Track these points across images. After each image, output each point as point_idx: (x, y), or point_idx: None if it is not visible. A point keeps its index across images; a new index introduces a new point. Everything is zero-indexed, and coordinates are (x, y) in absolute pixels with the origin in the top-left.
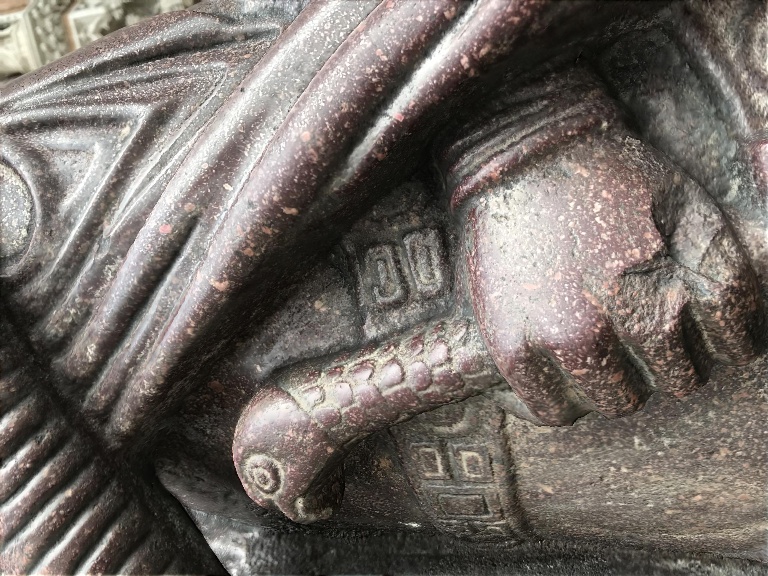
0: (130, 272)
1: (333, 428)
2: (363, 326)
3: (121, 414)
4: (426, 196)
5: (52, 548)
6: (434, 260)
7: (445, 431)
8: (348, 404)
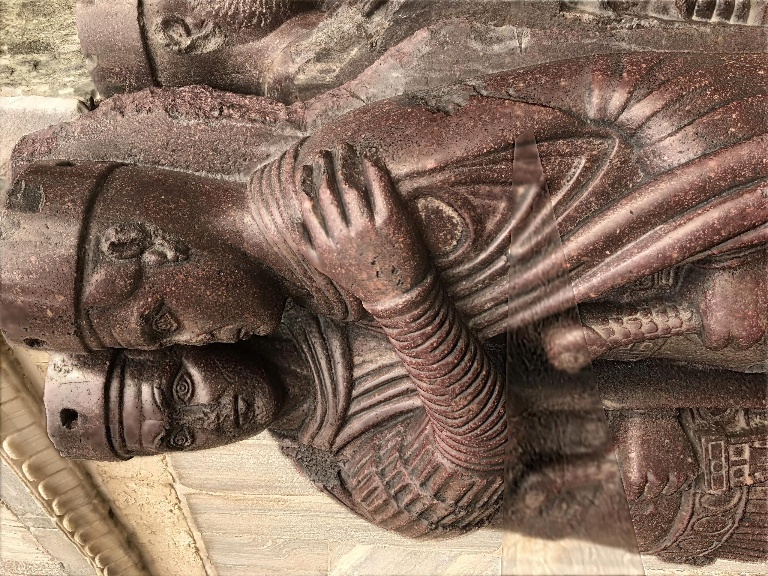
0: None
1: (615, 345)
2: (624, 295)
3: (493, 331)
4: None
5: (478, 396)
6: (671, 274)
7: None
8: (627, 338)
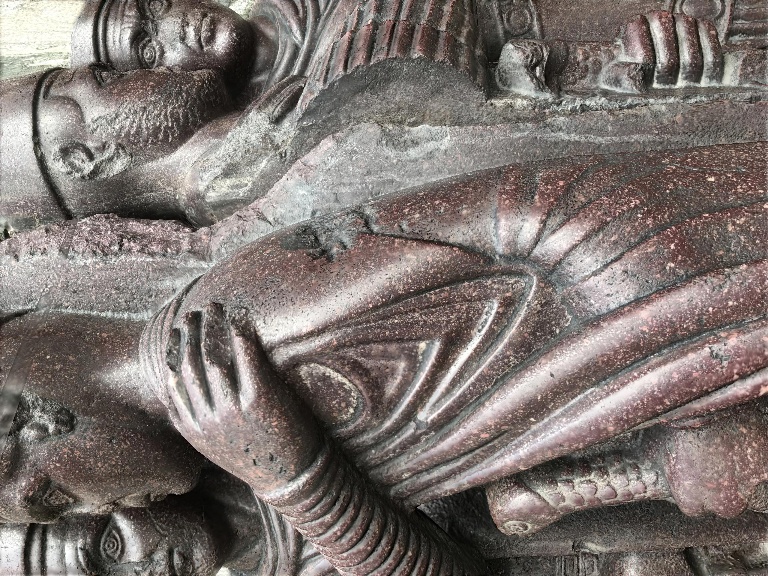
0: (453, 451)
1: (568, 513)
2: None
3: (420, 499)
4: None
5: None
6: None
7: None
8: (581, 505)
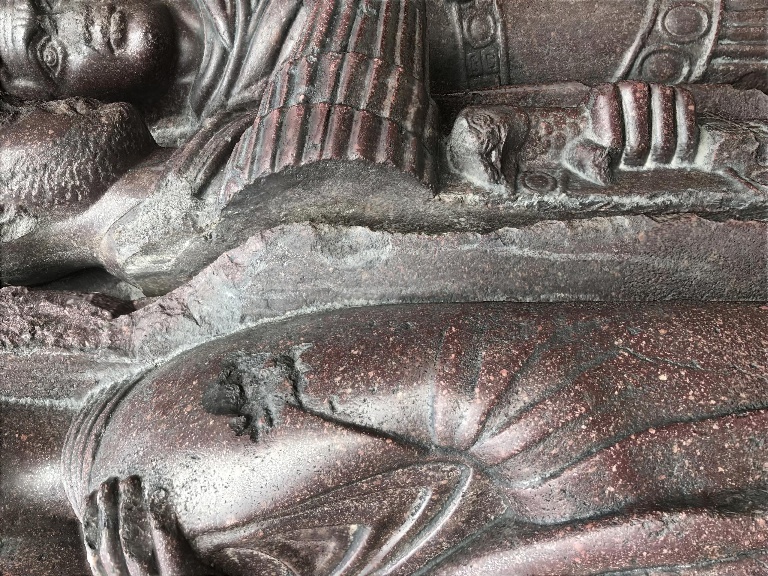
0: None
1: None
2: None
3: None
4: None
5: None
6: None
7: None
8: None
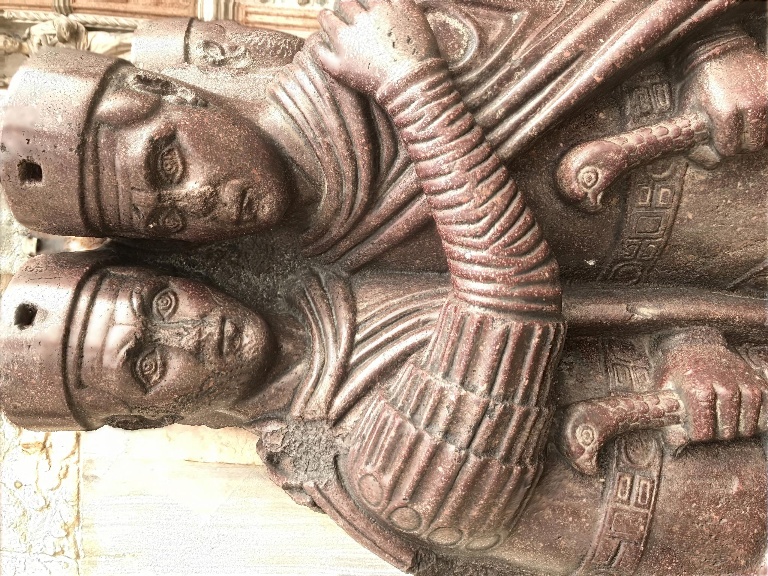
0: (542, 72)
1: (631, 154)
2: (628, 124)
3: (507, 148)
4: (664, 70)
5: (501, 189)
6: (666, 97)
7: (657, 177)
8: (641, 143)
